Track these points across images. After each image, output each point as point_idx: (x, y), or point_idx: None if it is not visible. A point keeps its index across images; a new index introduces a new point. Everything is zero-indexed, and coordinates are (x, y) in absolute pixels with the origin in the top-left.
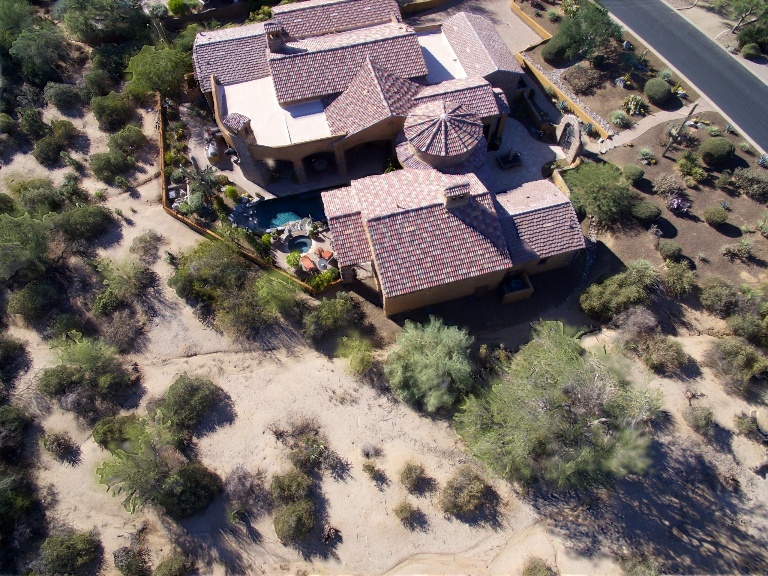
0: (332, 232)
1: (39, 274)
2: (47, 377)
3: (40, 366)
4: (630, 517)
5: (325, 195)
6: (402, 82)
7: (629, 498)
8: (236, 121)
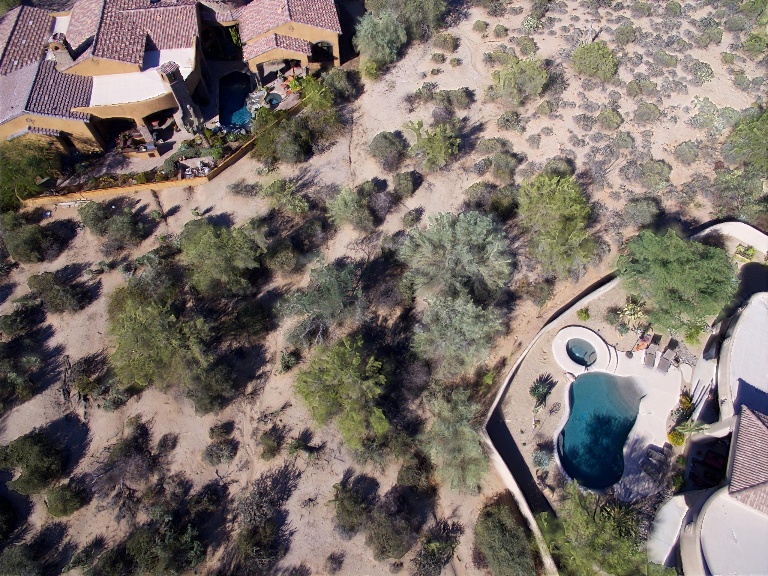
0: (287, 48)
1: (248, 273)
2: (361, 223)
3: (345, 250)
4: (456, 3)
5: (248, 56)
6: (154, 5)
7: (448, 2)
8: (169, 67)
